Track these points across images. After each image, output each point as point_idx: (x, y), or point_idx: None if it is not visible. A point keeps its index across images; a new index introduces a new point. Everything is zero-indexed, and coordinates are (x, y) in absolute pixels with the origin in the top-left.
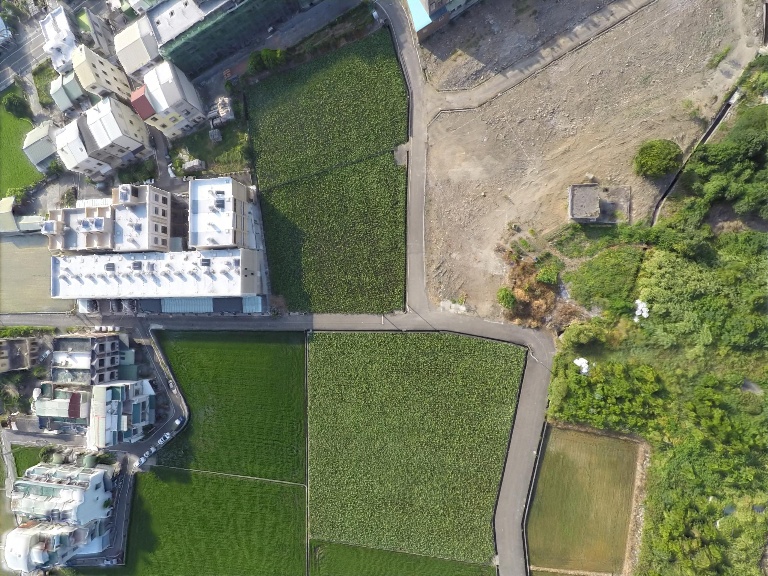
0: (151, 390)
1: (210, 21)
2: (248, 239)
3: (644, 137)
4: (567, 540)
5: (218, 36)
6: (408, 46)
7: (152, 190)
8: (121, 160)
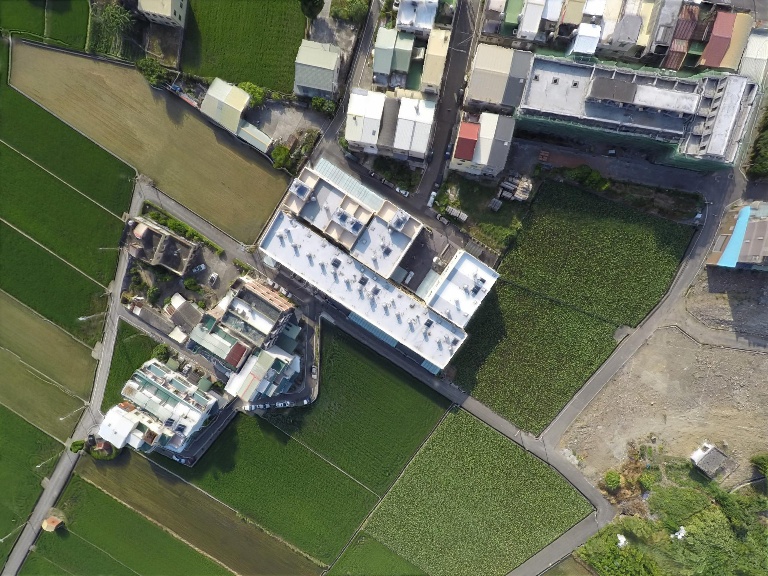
0: (298, 368)
1: (585, 124)
2: None
3: None
4: None
5: (573, 130)
6: (697, 260)
7: None
8: (392, 155)
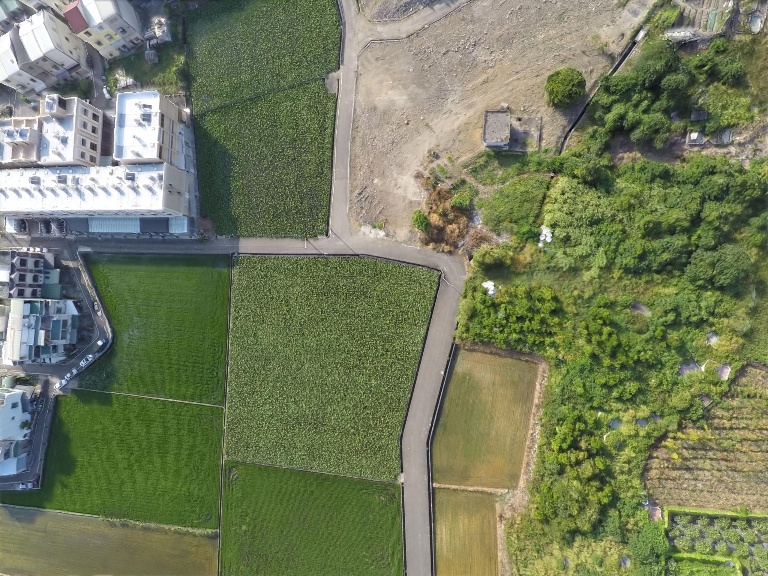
0: (74, 310)
1: None
2: (177, 159)
3: (556, 70)
4: (468, 458)
5: None
6: None
7: (81, 104)
8: (56, 78)
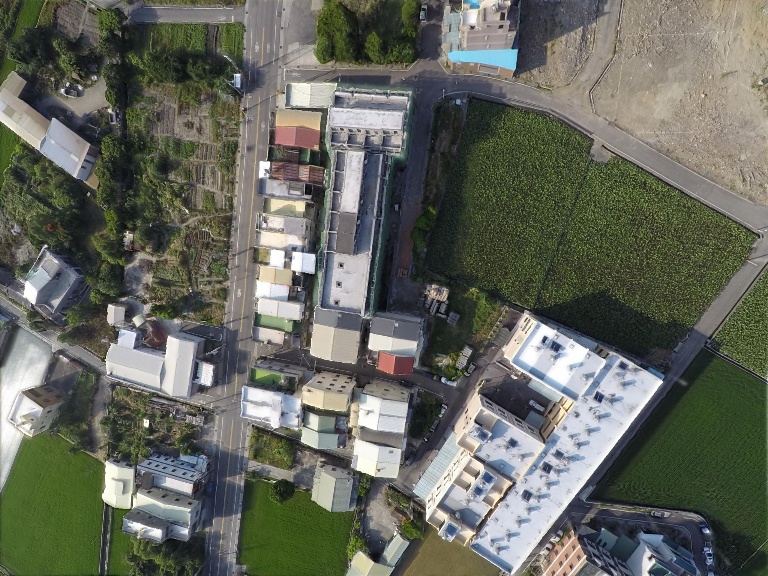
0: (657, 537)
1: (376, 252)
2: None
3: None
4: None
5: (380, 256)
6: (507, 89)
7: None
8: (407, 424)
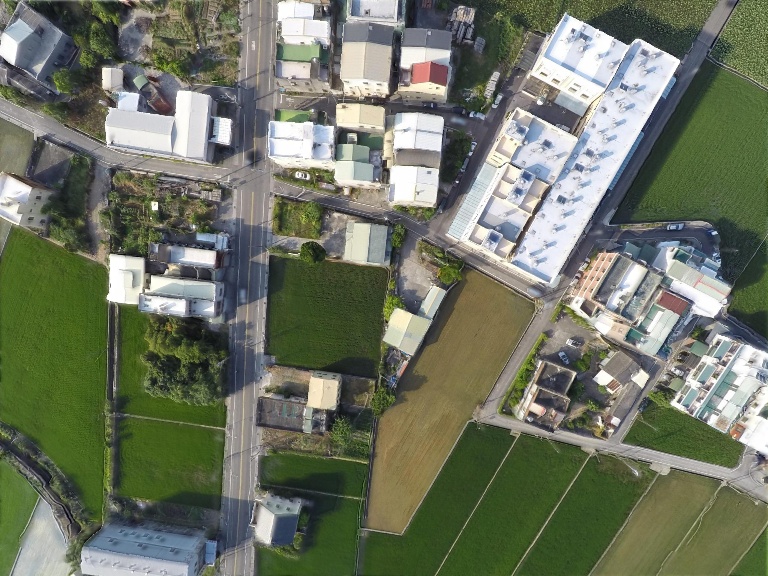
0: (674, 243)
1: None
2: None
3: None
4: None
5: None
6: None
7: None
8: None
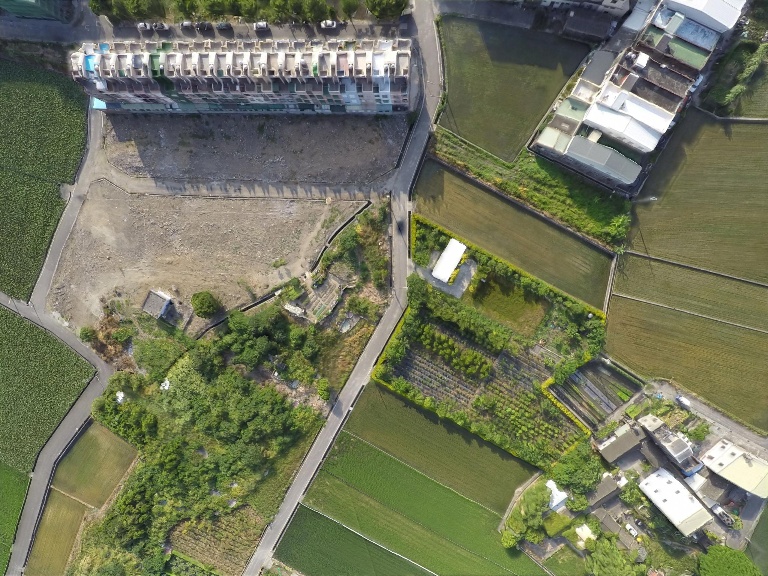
0: None
1: None
2: None
3: (217, 284)
4: (78, 481)
5: None
6: (97, 110)
7: None
8: None
